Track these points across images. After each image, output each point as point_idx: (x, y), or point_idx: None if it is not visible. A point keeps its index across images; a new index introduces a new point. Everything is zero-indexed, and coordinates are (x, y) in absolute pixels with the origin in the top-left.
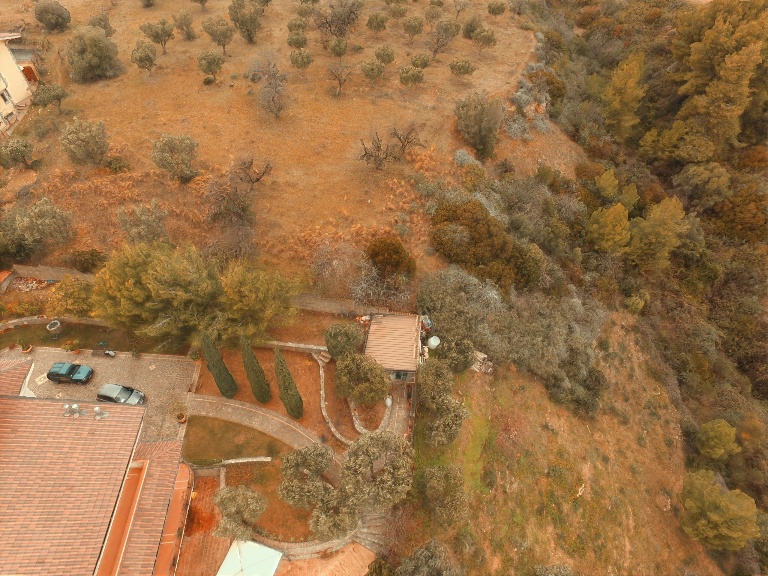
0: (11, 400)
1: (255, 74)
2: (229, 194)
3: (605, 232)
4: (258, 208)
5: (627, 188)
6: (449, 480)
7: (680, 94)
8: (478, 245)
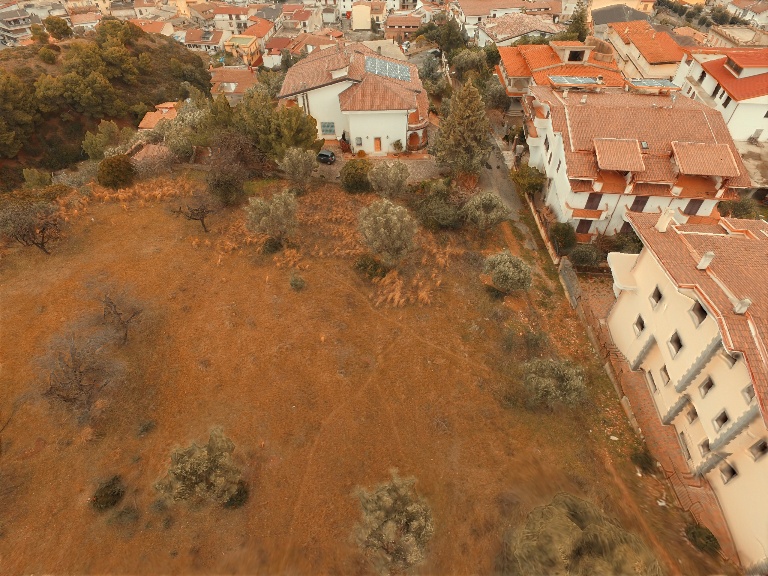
0: (328, 82)
1: (103, 491)
2: (220, 172)
3: None
4: (208, 217)
5: None
6: (162, 125)
7: None
8: None
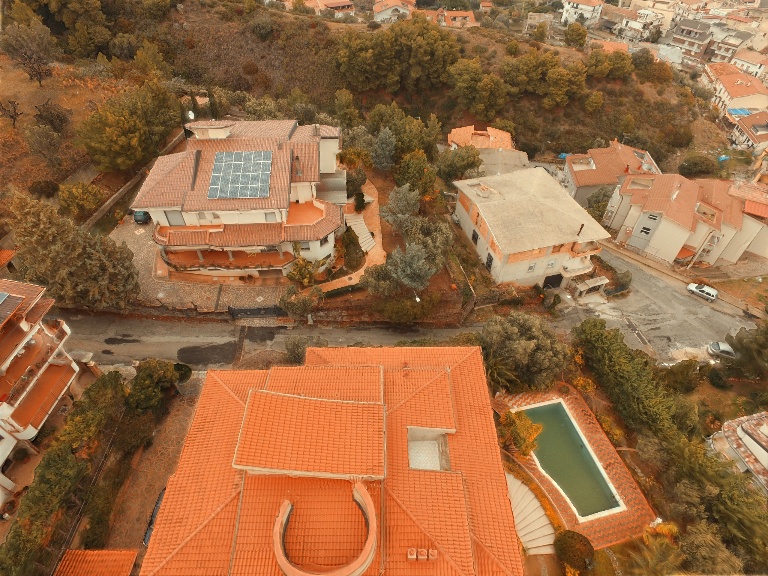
0: None
1: None
2: (43, 106)
3: (149, 68)
4: None
5: (113, 61)
6: None
7: (57, 10)
8: (148, 73)
